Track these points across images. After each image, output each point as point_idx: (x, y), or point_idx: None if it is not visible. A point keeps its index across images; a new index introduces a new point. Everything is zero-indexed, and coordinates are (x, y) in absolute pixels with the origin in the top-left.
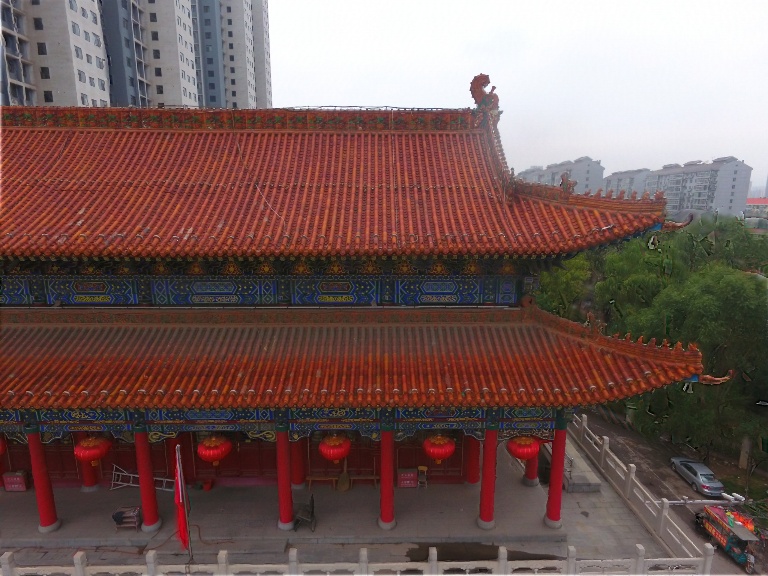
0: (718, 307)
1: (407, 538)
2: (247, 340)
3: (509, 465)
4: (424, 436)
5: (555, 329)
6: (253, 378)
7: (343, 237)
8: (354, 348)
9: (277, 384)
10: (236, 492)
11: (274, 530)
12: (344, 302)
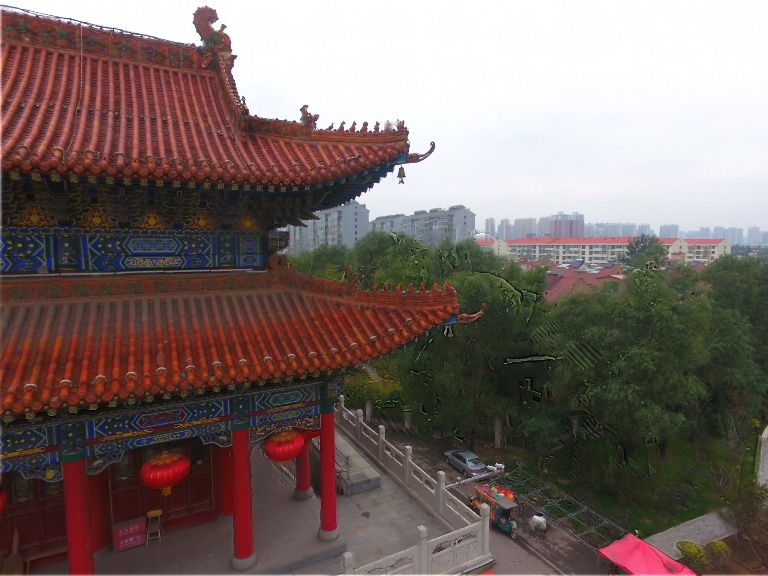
0: (465, 304)
1: None
2: None
3: (278, 482)
4: (141, 459)
5: (310, 291)
6: None
7: None
8: None
9: None
10: None
11: None
12: None
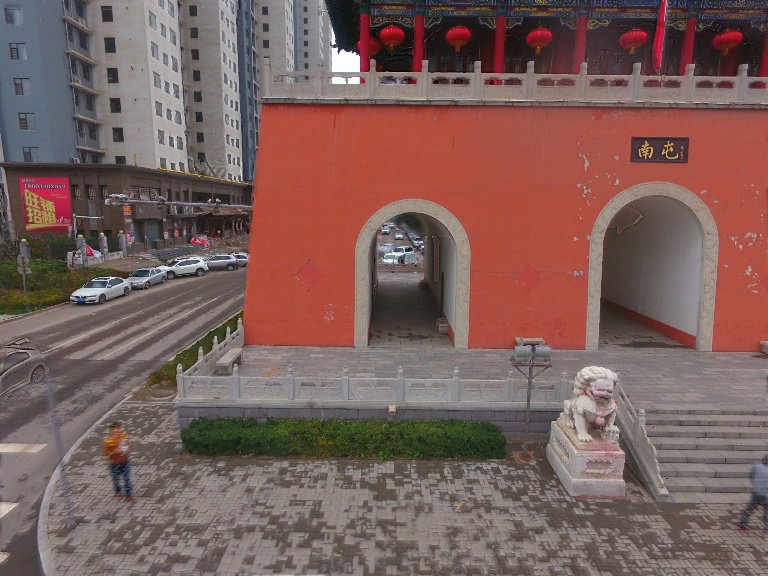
0: None
1: None
2: None
3: None
4: None
5: None
6: None
7: None
8: None
9: None
10: None
11: None
12: None
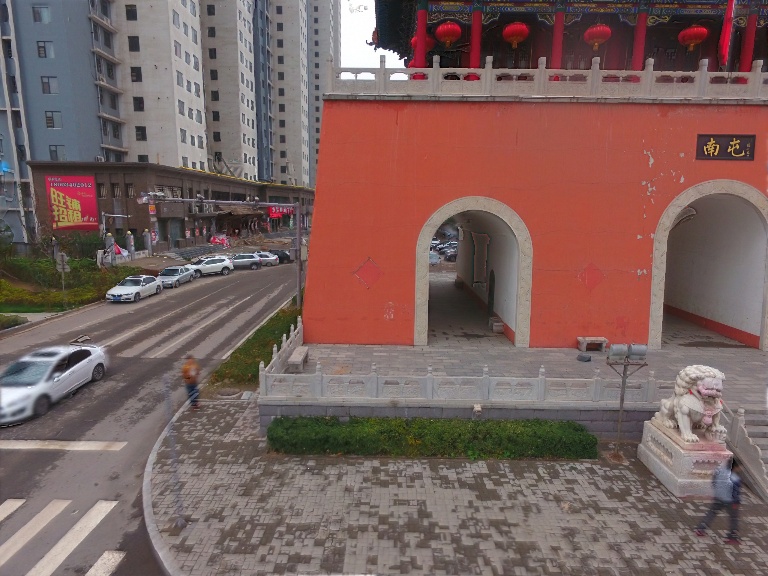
0: None
1: None
2: None
3: None
4: None
5: None
6: None
7: None
8: None
9: None
10: None
11: None
12: None
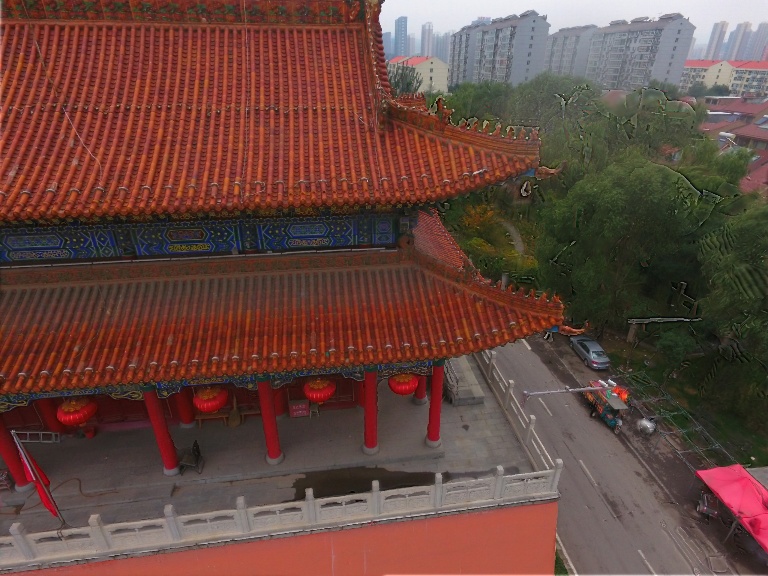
0: (625, 201)
1: (294, 470)
2: (87, 302)
3: None
4: (304, 381)
5: (432, 272)
6: (92, 351)
7: (174, 186)
8: (213, 305)
9: (121, 357)
10: (122, 437)
11: (160, 476)
12: (200, 251)
